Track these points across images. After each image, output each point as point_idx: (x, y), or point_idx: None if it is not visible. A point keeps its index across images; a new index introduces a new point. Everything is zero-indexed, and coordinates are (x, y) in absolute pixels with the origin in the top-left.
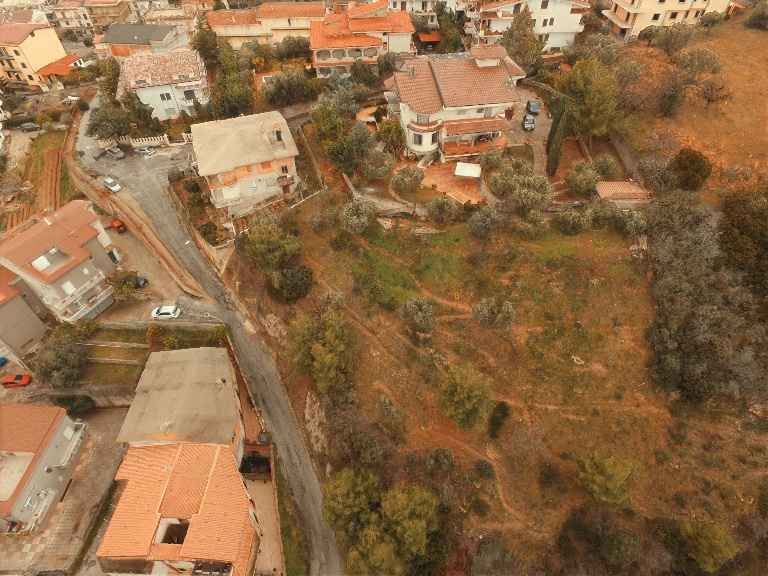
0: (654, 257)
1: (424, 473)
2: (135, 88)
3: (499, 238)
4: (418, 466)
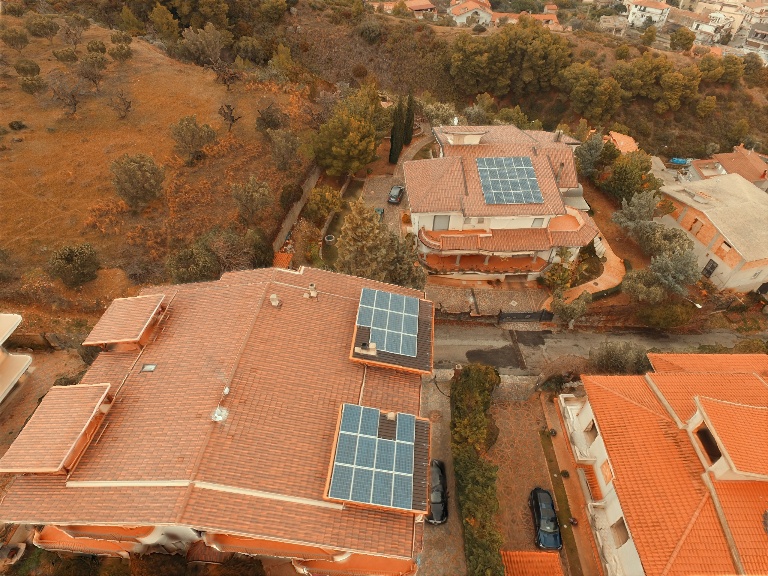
0: None
1: None
2: None
3: None
4: None
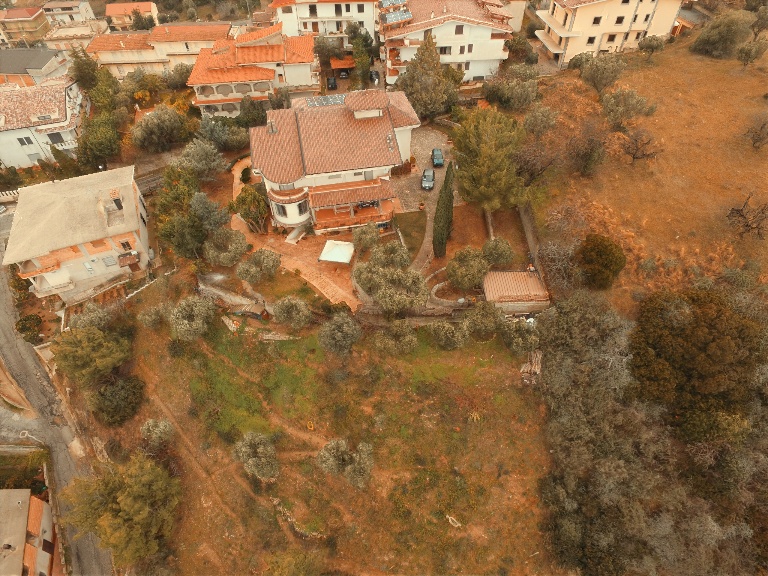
0: (547, 387)
1: None
2: None
3: (361, 351)
4: None
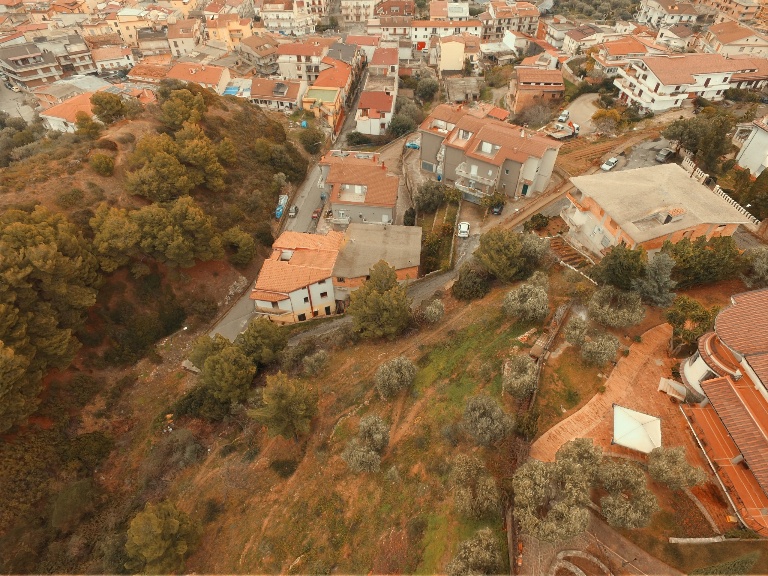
0: None
1: None
2: (759, 126)
3: None
4: None
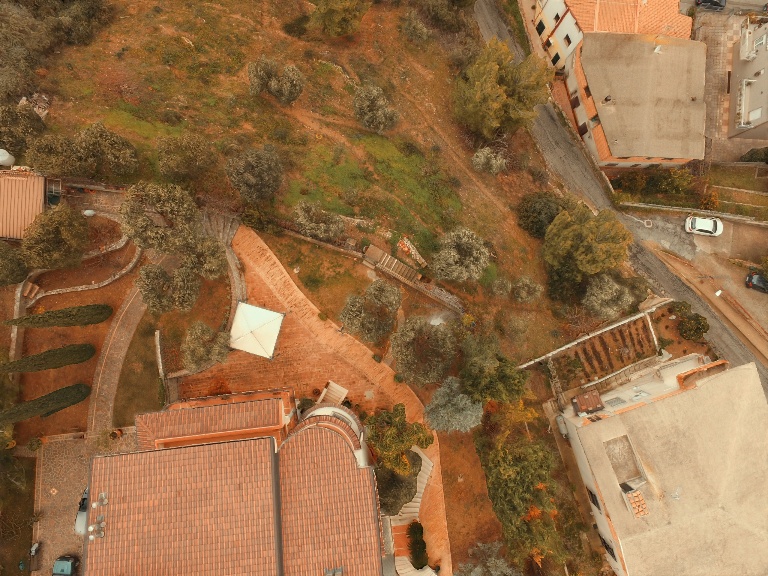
0: None
1: (383, 0)
2: None
3: None
4: (388, 5)
